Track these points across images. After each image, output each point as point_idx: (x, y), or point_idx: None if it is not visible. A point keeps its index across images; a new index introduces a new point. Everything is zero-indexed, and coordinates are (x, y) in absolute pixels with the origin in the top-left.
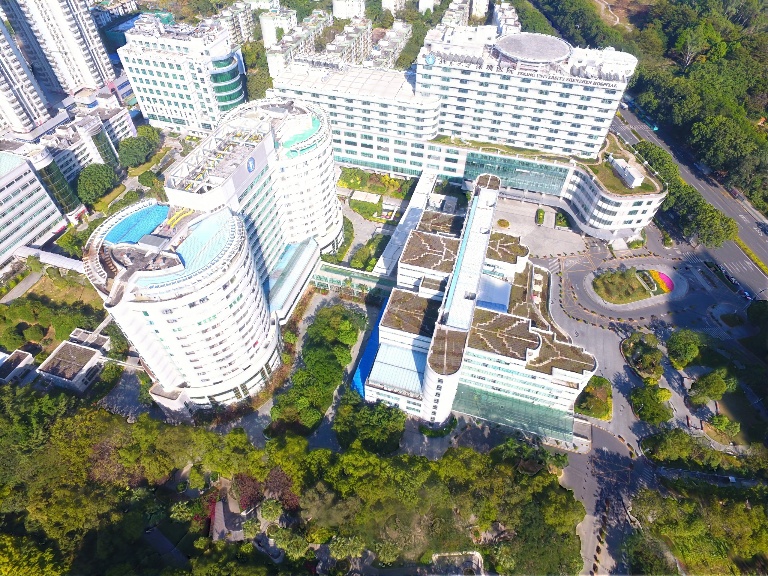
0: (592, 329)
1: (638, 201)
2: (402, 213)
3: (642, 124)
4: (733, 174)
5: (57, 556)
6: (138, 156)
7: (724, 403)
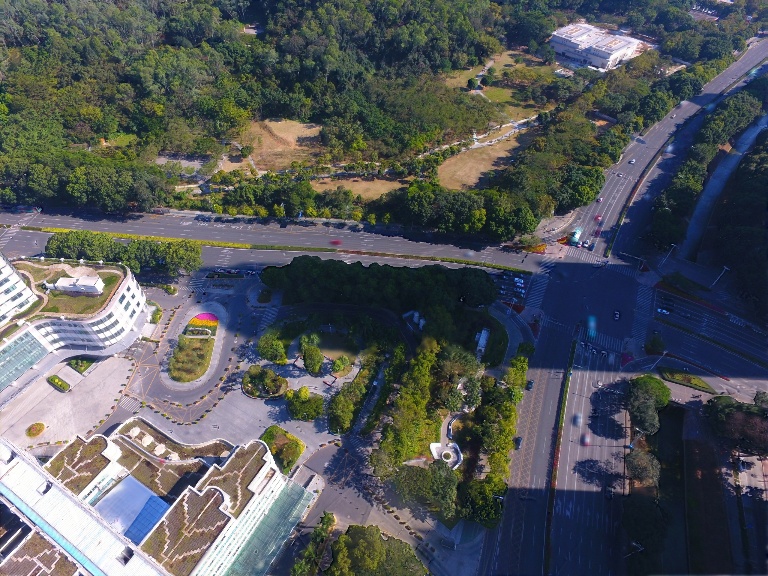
0: (218, 409)
1: (120, 297)
2: None
3: (22, 215)
4: (142, 203)
5: None
6: None
7: (324, 350)
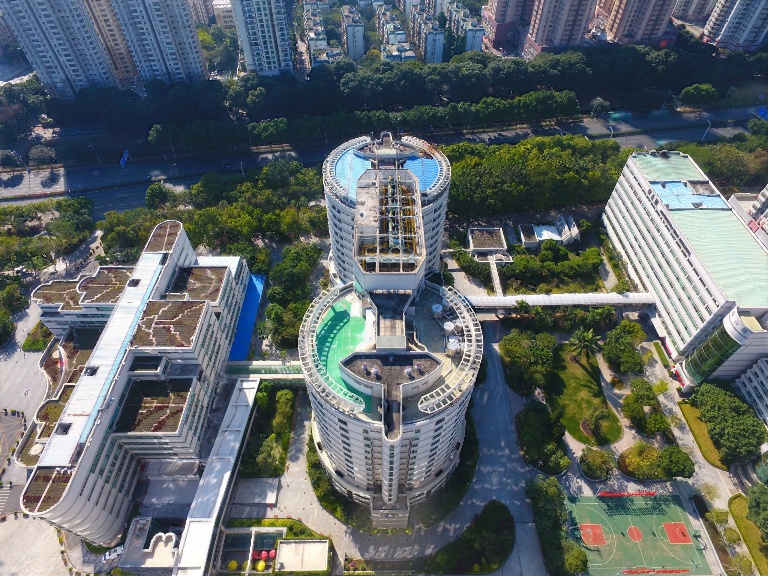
0: (3, 405)
1: None
2: (238, 570)
3: None
4: None
5: None
6: (759, 512)
7: None
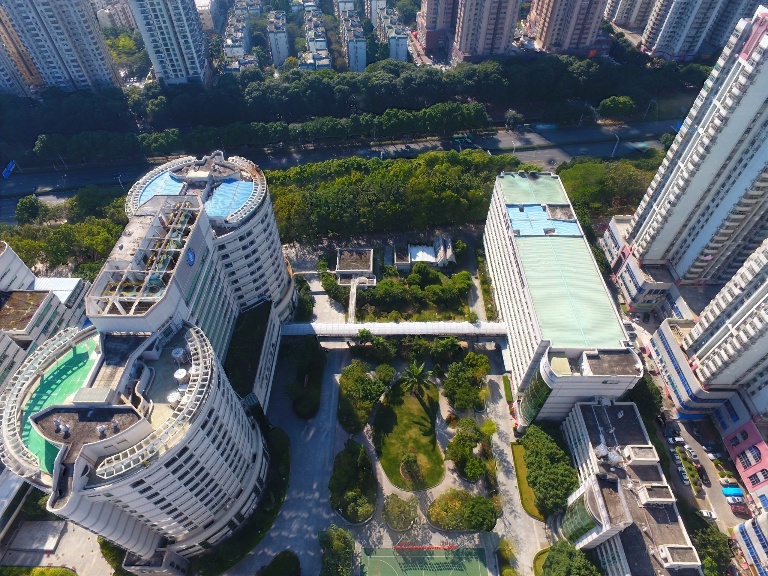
0: None
1: None
2: None
3: None
4: None
5: (272, 183)
6: (551, 573)
7: None
